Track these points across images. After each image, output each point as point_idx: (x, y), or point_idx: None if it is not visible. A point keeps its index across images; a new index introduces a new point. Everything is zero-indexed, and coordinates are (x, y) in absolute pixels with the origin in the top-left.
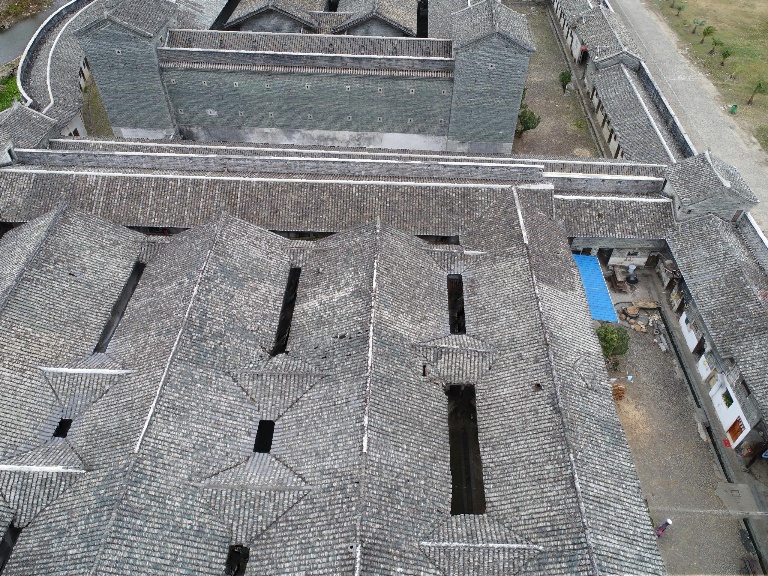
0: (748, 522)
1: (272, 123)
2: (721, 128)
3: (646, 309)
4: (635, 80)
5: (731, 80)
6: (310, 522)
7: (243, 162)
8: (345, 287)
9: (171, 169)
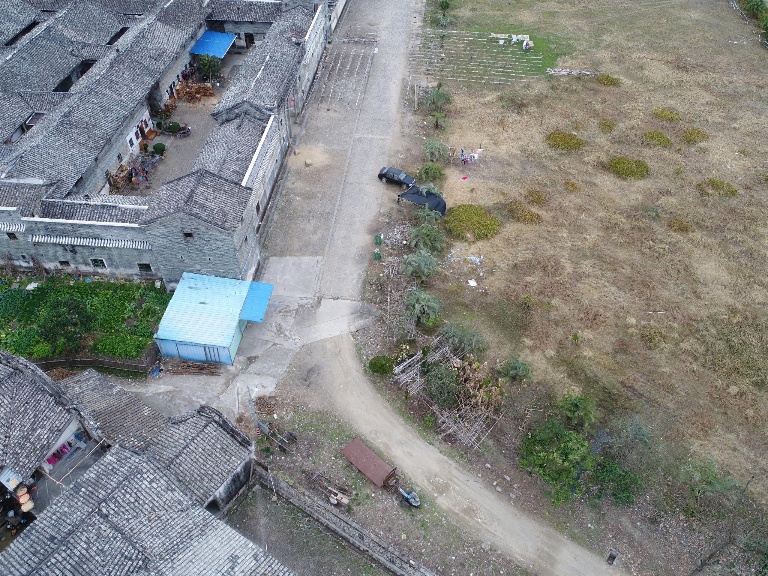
0: None
1: None
2: None
3: None
4: None
5: None
6: None
7: None
8: None
9: None
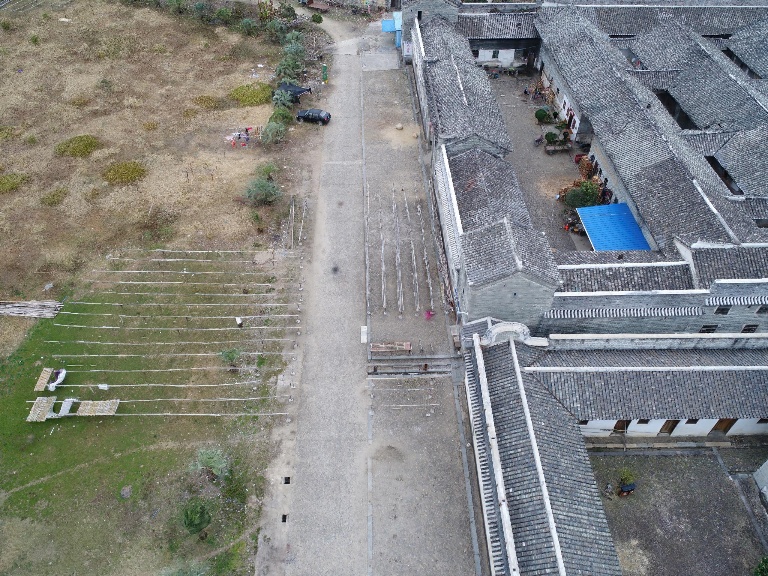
0: None
1: None
2: None
3: None
4: None
5: None
6: None
7: None
8: None
9: None
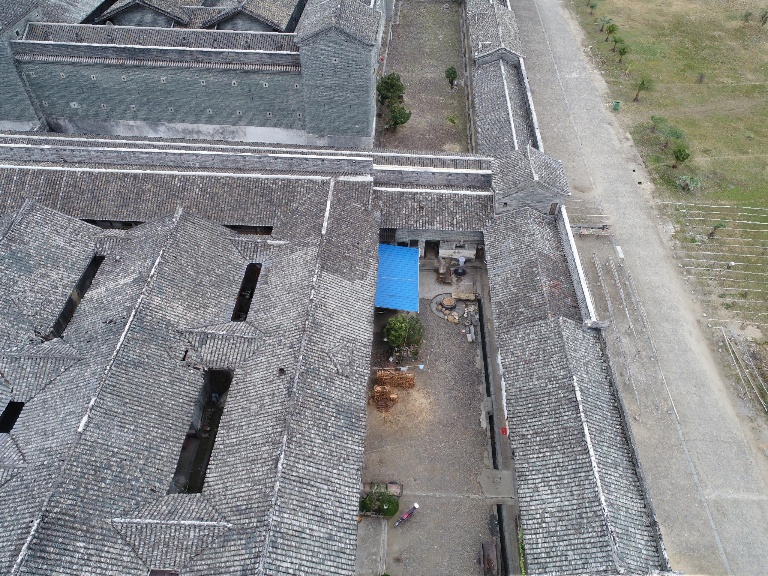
0: (502, 507)
1: (136, 116)
2: (599, 124)
3: (465, 300)
4: (511, 76)
5: (625, 77)
6: (13, 498)
7: (78, 153)
8: (131, 274)
9: (10, 159)
